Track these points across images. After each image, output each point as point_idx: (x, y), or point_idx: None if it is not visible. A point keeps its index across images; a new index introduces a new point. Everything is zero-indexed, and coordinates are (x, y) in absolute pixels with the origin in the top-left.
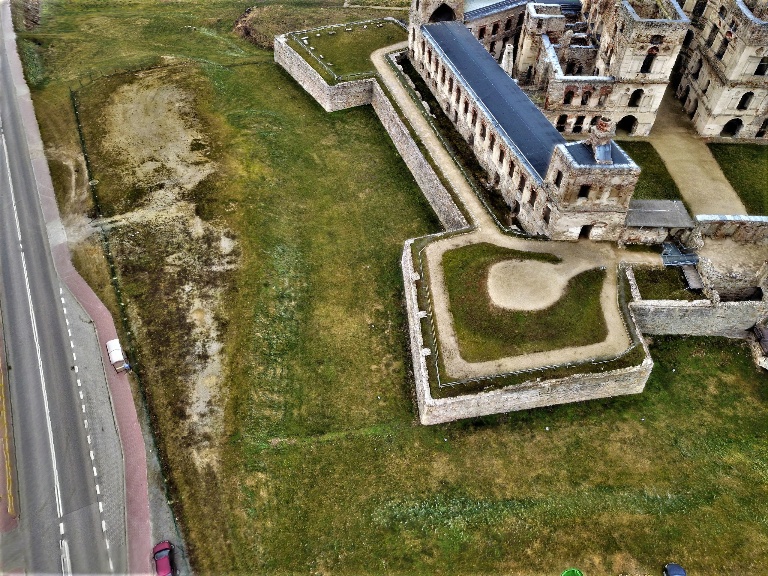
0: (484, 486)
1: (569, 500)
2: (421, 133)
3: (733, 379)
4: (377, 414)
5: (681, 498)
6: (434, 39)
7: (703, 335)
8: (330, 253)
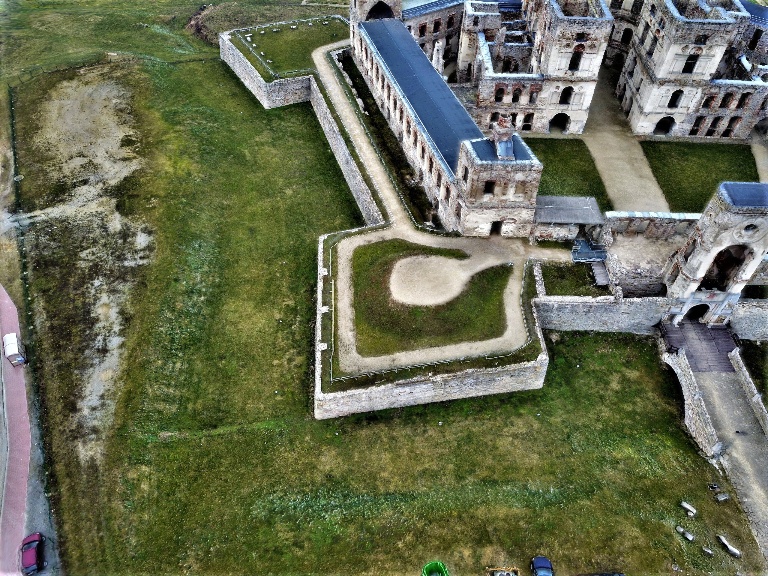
0: (369, 480)
1: (451, 494)
2: (350, 130)
3: (637, 375)
4: (272, 408)
5: (563, 492)
6: (369, 36)
7: (611, 331)
8: (248, 249)
